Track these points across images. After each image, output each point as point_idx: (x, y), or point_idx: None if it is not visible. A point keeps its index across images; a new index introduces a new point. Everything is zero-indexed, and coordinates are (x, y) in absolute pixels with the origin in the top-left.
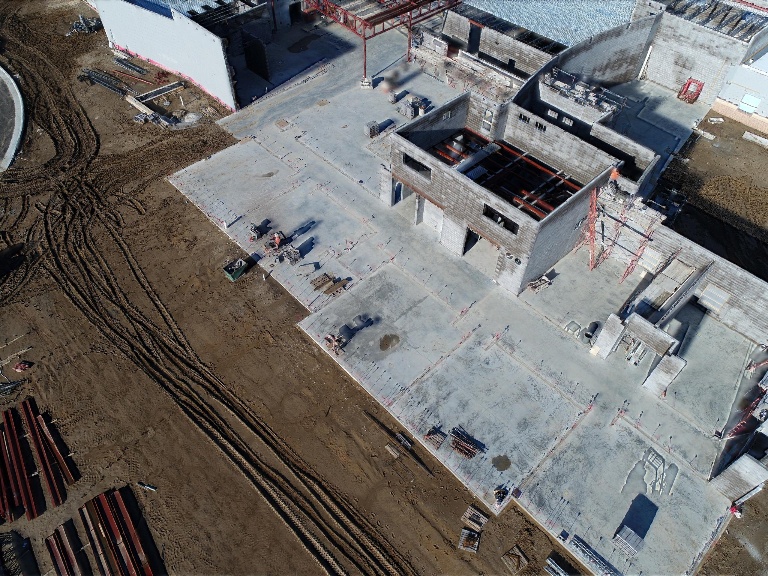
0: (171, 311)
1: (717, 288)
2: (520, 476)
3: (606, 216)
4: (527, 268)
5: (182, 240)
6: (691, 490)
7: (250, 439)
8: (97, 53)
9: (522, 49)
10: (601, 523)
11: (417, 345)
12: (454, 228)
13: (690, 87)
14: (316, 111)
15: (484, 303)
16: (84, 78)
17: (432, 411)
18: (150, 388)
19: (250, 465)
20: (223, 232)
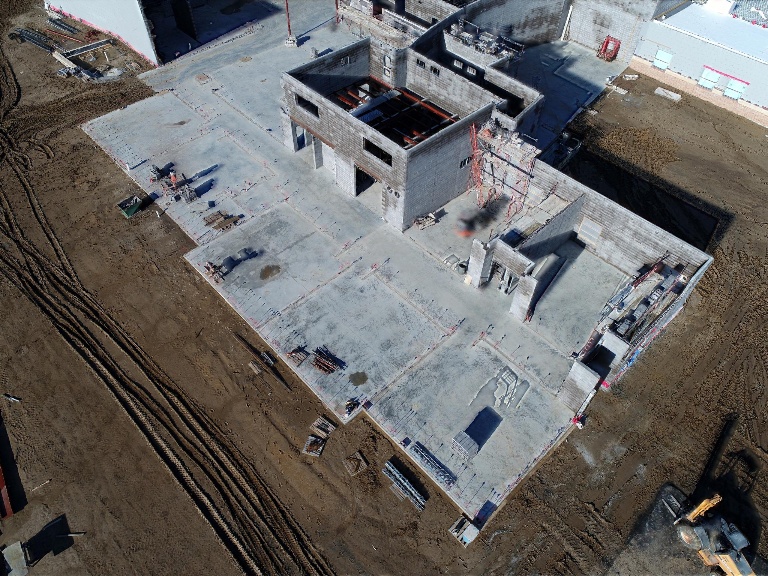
0: (63, 244)
1: (591, 221)
2: (374, 390)
3: (493, 156)
4: (406, 201)
5: (85, 181)
6: (538, 404)
7: (119, 357)
8: (32, 14)
9: (442, 7)
10: (444, 432)
11: (296, 275)
12: (344, 167)
13: (609, 45)
14: (237, 67)
15: (369, 238)
16: (15, 36)
17: (299, 333)
18: (31, 312)
19: (115, 379)
20: (126, 174)
